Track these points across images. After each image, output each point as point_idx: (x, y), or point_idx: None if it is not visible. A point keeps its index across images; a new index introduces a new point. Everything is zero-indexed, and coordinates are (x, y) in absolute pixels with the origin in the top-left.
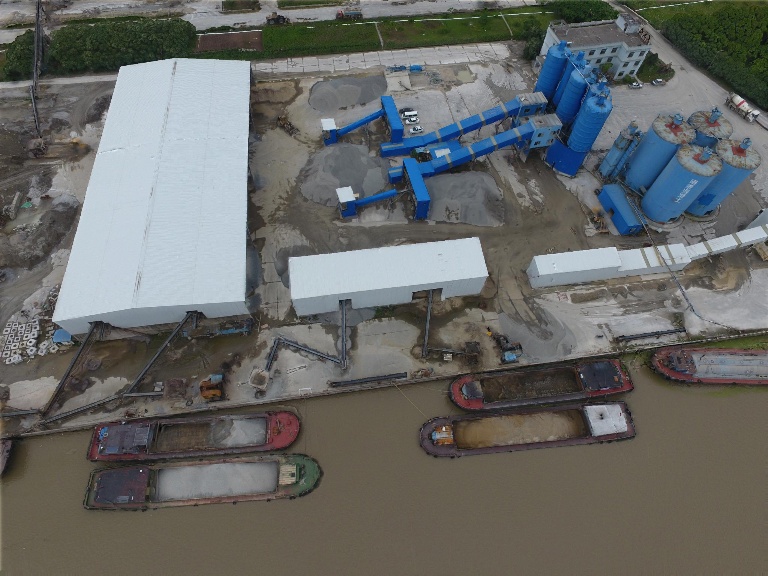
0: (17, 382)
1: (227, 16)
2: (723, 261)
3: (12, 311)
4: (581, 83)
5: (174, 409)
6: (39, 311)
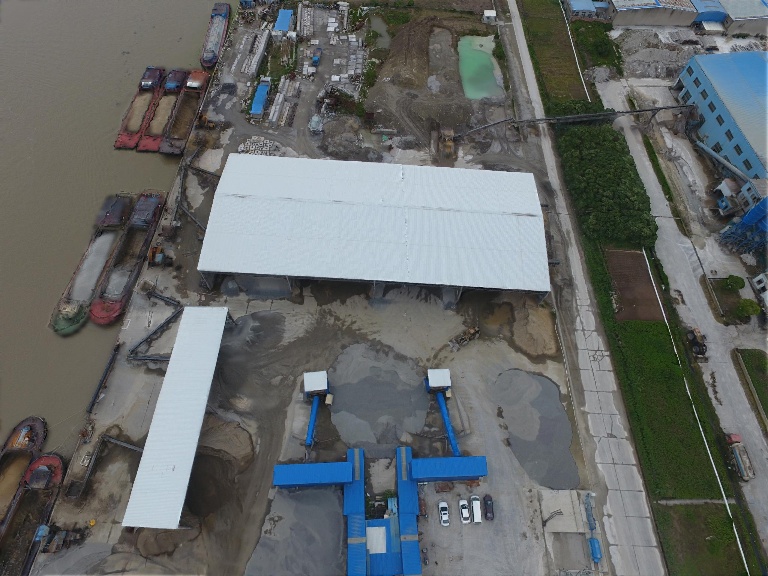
0: (223, 152)
1: (696, 283)
2: None
3: (283, 142)
4: None
5: None
6: None
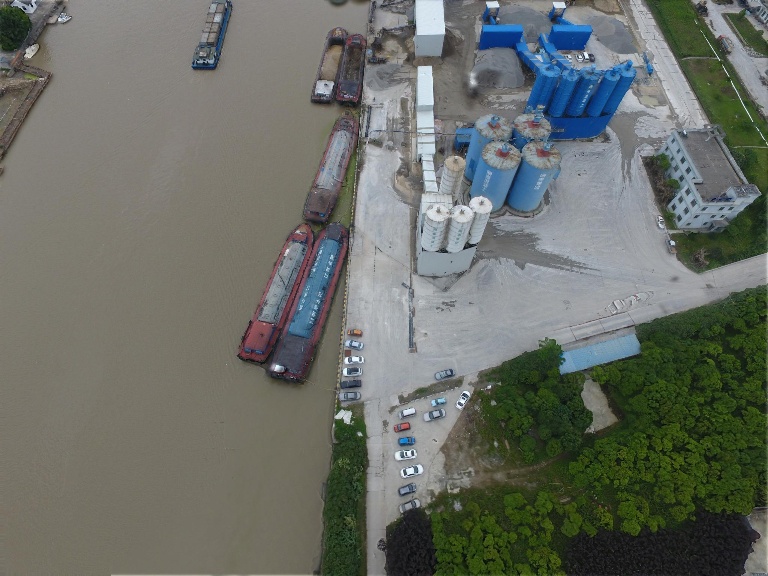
0: None
1: None
2: (421, 191)
3: None
4: None
5: None
6: None
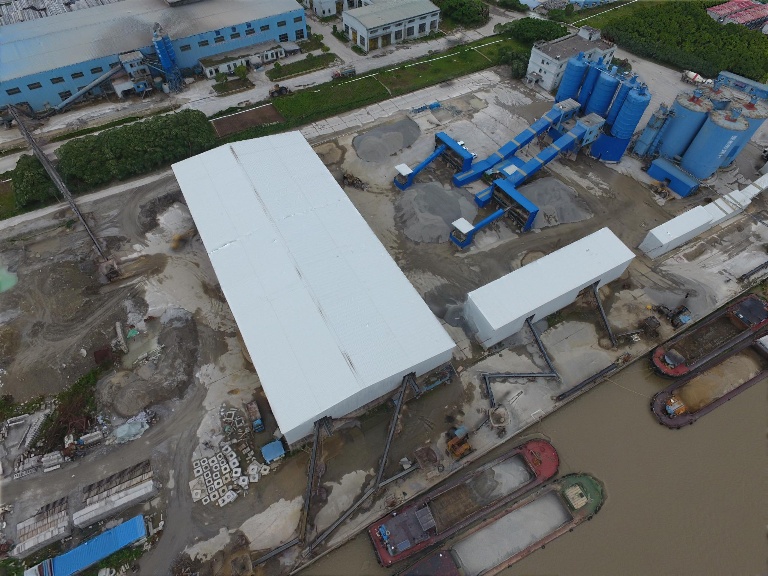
0: (246, 521)
1: (226, 98)
2: (764, 196)
3: (190, 449)
4: (614, 82)
5: (430, 480)
6: (221, 437)
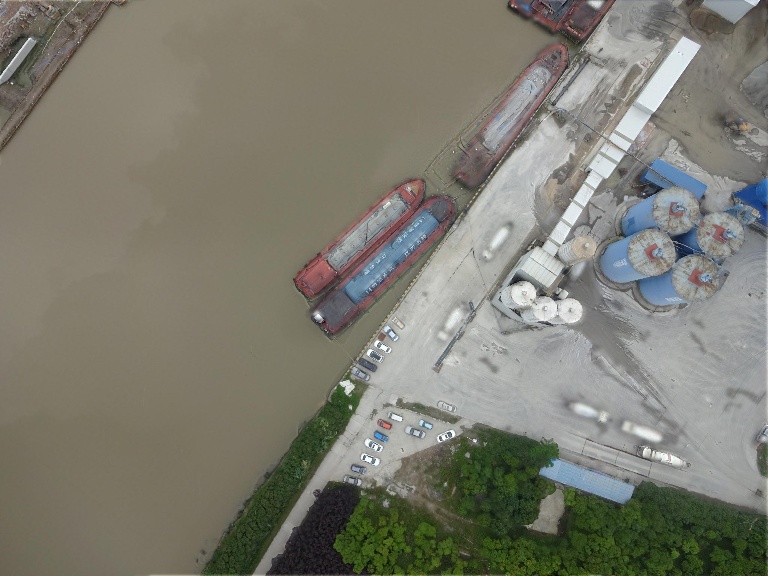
0: None
1: None
2: (561, 211)
3: None
4: None
5: None
6: None
